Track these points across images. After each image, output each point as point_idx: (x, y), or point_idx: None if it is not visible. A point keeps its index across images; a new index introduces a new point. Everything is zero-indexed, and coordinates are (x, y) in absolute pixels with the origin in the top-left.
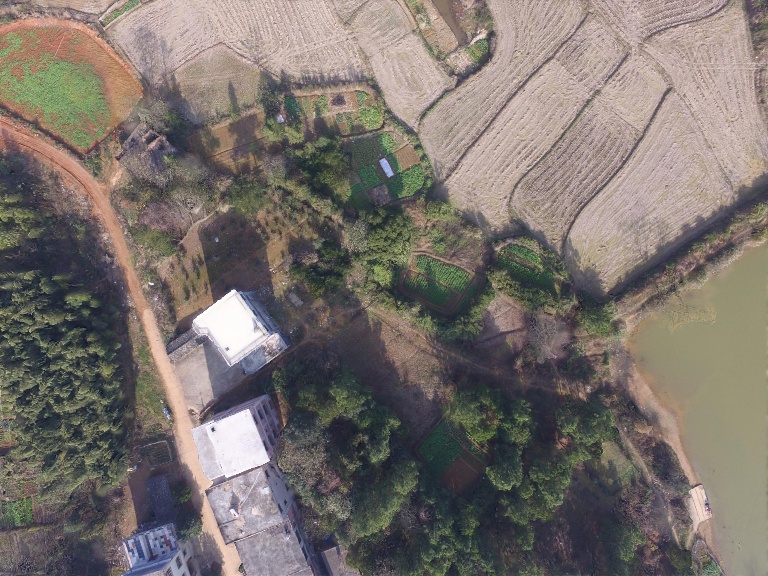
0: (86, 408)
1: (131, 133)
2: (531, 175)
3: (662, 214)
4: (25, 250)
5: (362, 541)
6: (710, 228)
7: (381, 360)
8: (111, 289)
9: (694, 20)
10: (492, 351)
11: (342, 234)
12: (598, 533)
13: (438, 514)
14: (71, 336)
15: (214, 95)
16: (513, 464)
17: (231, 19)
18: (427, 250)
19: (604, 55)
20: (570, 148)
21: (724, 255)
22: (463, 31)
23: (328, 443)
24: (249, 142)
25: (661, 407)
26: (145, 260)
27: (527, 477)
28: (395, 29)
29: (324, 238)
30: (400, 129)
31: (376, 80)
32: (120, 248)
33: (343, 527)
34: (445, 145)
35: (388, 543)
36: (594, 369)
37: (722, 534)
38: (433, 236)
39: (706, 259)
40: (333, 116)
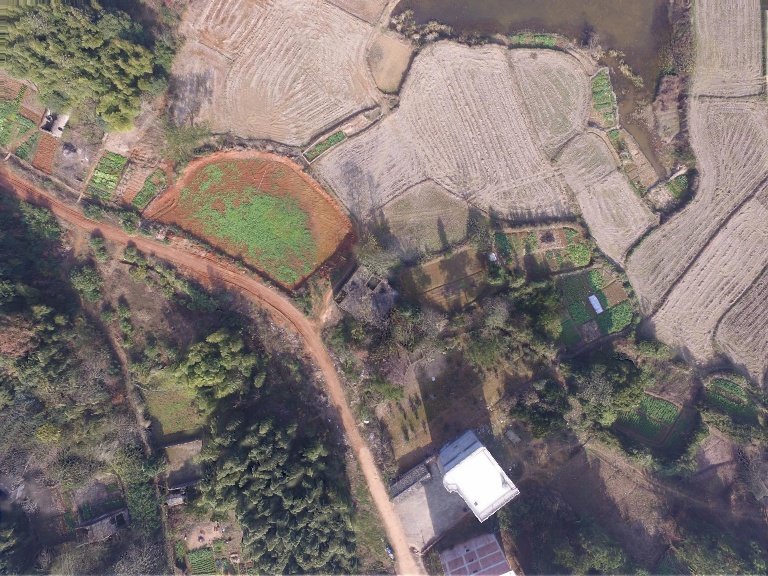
0: (330, 562)
1: (351, 276)
2: (734, 310)
3: None
4: (248, 397)
5: None
6: None
7: (601, 497)
8: (326, 428)
9: None
10: (705, 485)
11: (556, 371)
12: None
13: None
14: (315, 493)
15: (423, 231)
16: None
17: (438, 154)
18: None
19: None
20: None
21: None
22: (662, 166)
23: None
24: (459, 279)
25: None
26: (359, 398)
27: None
28: (601, 166)
29: (546, 380)
30: (610, 267)
31: (583, 217)
32: (333, 386)
33: None
34: (651, 281)
35: None
36: None
37: None
38: None
39: None
40: (542, 253)
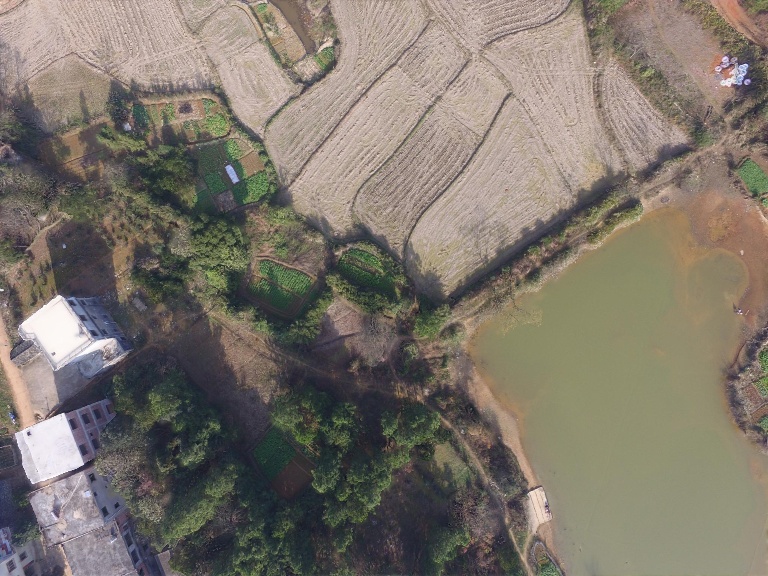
0: None
1: None
2: (373, 180)
3: (502, 218)
4: None
5: (185, 544)
6: (549, 231)
7: (220, 364)
8: None
9: (533, 26)
10: (330, 354)
11: None
12: (427, 535)
13: (250, 517)
14: None
15: (66, 104)
16: (327, 467)
17: (83, 29)
18: (270, 255)
19: (446, 62)
20: (411, 153)
21: (558, 258)
22: (311, 39)
23: (146, 446)
24: (99, 150)
25: (501, 409)
26: None
27: (344, 479)
28: (242, 38)
29: (164, 244)
30: (244, 136)
31: (223, 88)
32: None
33: (160, 530)
34: (290, 151)
35: (214, 546)
36: (432, 372)
37: (563, 536)
38: (276, 241)
39: (542, 262)
40: (181, 124)
